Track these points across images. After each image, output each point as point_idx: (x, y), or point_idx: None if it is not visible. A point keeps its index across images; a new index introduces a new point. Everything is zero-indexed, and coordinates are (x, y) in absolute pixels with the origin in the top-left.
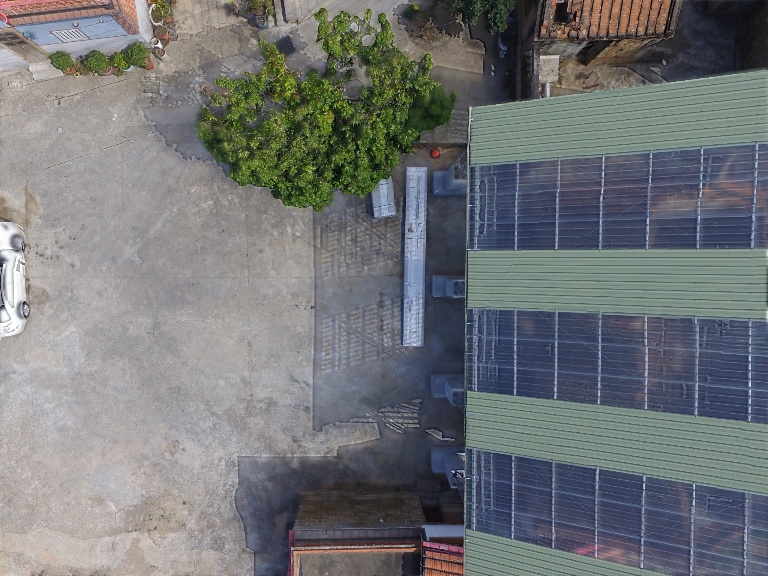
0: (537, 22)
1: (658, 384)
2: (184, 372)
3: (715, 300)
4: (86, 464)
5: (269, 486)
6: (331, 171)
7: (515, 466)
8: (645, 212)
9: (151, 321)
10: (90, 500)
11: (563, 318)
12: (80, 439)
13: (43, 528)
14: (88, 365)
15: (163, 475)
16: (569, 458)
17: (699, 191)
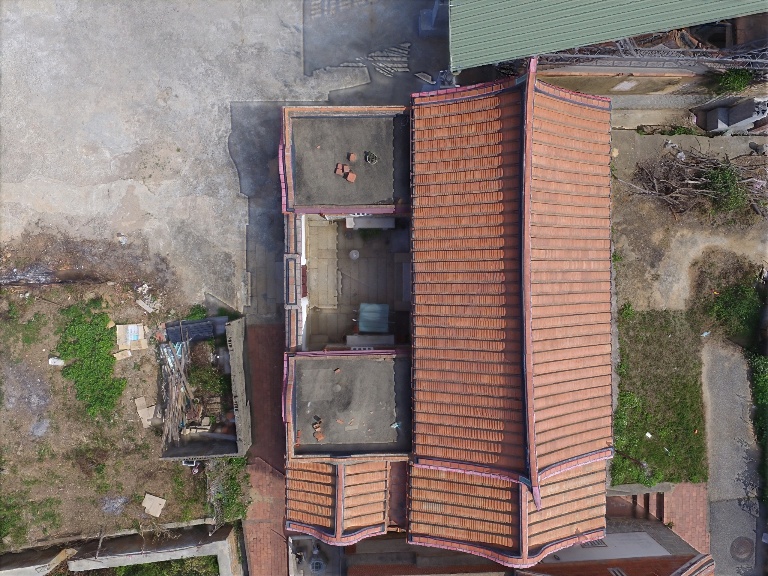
0: None
1: None
2: (175, 18)
3: None
4: (80, 112)
5: (262, 131)
6: None
7: None
8: None
9: None
10: (85, 148)
11: None
12: (74, 87)
13: (39, 176)
14: (80, 12)
15: (157, 122)
16: None
17: None
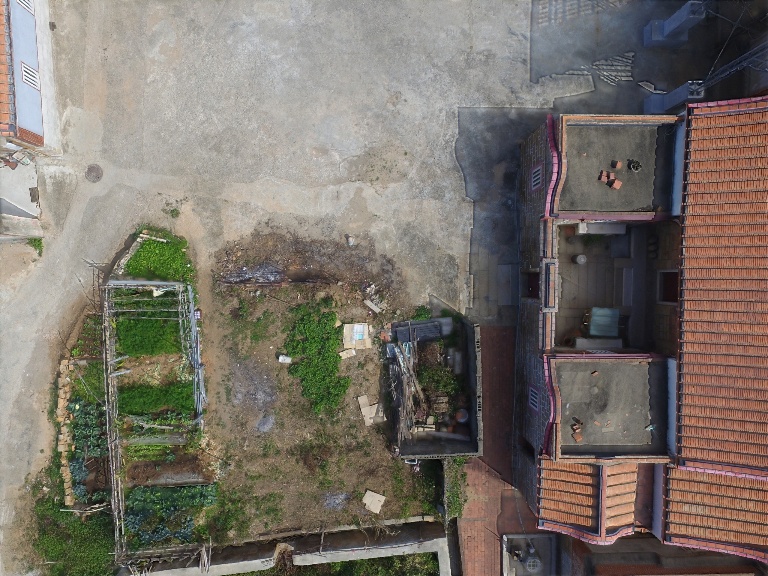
0: None
1: None
2: (407, 24)
3: None
4: (311, 114)
5: (488, 136)
6: None
7: None
8: None
9: None
10: (315, 150)
11: None
12: (306, 90)
13: (270, 176)
14: (314, 17)
15: (385, 126)
16: None
17: None
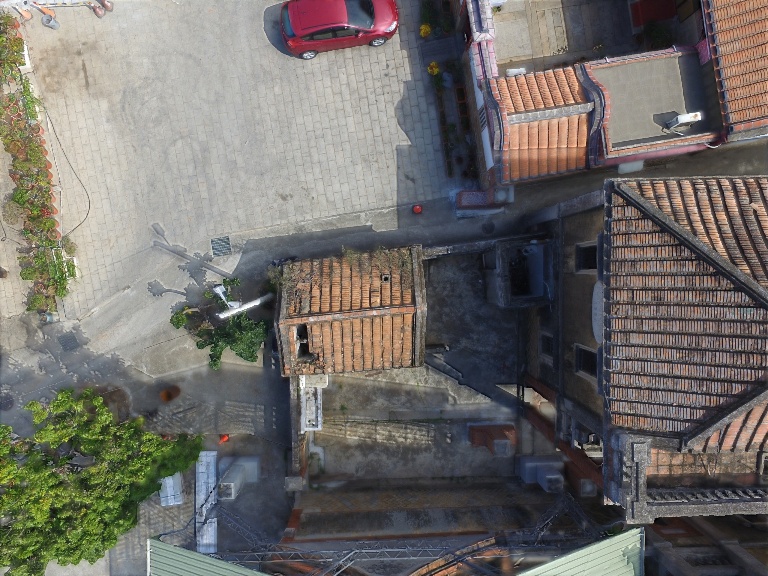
0: (280, 363)
1: None
2: None
3: None
4: None
5: None
6: None
7: None
8: None
9: None
10: None
11: None
12: None
13: None
14: None
15: None
16: None
17: None
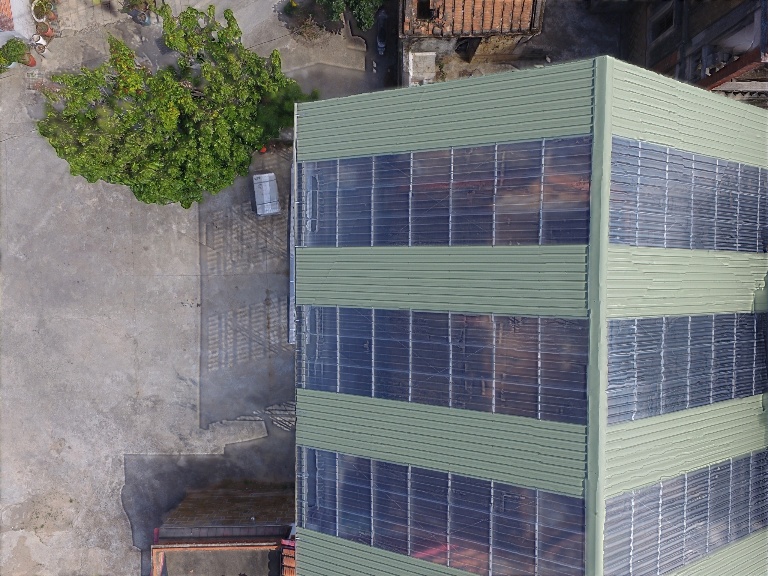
0: (400, 19)
1: (461, 381)
2: (70, 370)
3: (509, 297)
4: None
5: (156, 484)
6: (178, 168)
7: (339, 464)
8: (448, 209)
9: (36, 319)
10: None
11: (379, 315)
12: None
13: None
14: None
15: (49, 473)
16: (385, 455)
17: (494, 187)
